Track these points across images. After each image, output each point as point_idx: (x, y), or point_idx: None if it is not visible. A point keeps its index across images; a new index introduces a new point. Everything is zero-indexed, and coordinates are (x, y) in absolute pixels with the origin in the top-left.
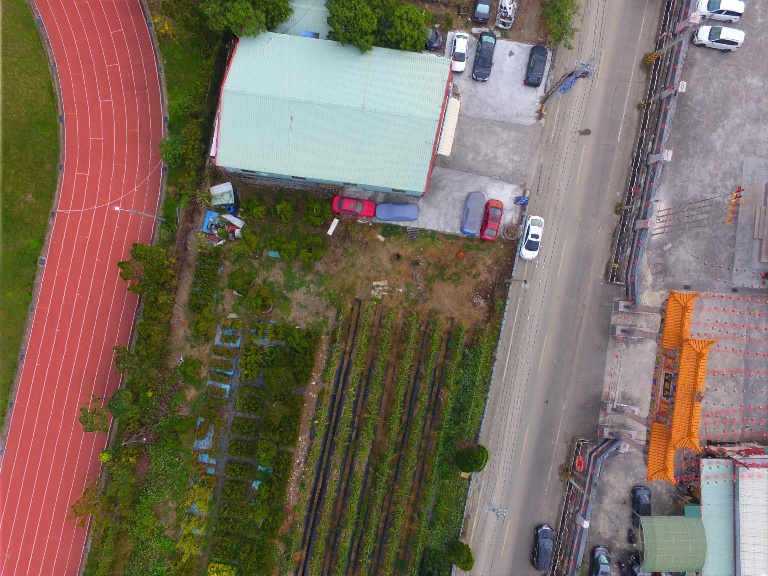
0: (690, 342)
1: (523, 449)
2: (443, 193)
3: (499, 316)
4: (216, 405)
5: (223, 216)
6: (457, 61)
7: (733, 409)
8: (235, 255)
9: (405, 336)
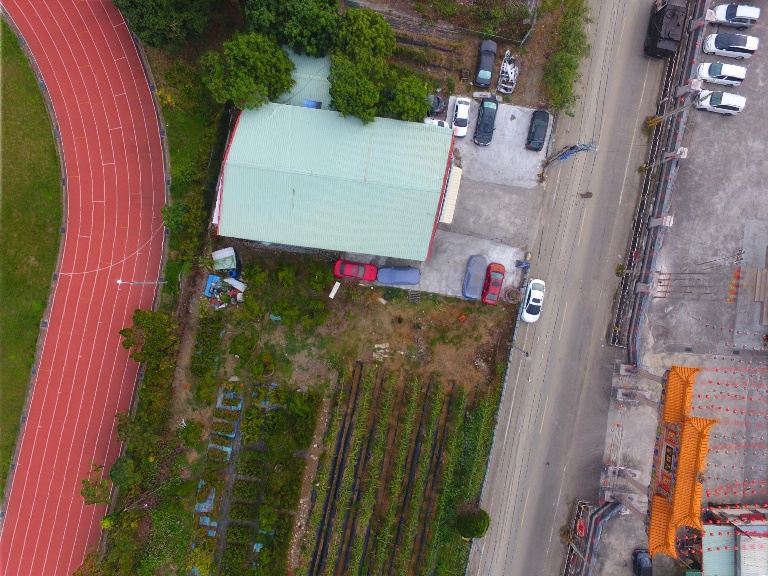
0: (691, 421)
1: (524, 511)
2: (445, 256)
3: (500, 379)
4: (217, 468)
5: (225, 280)
6: (459, 126)
7: (734, 471)
8: None
9: (406, 399)
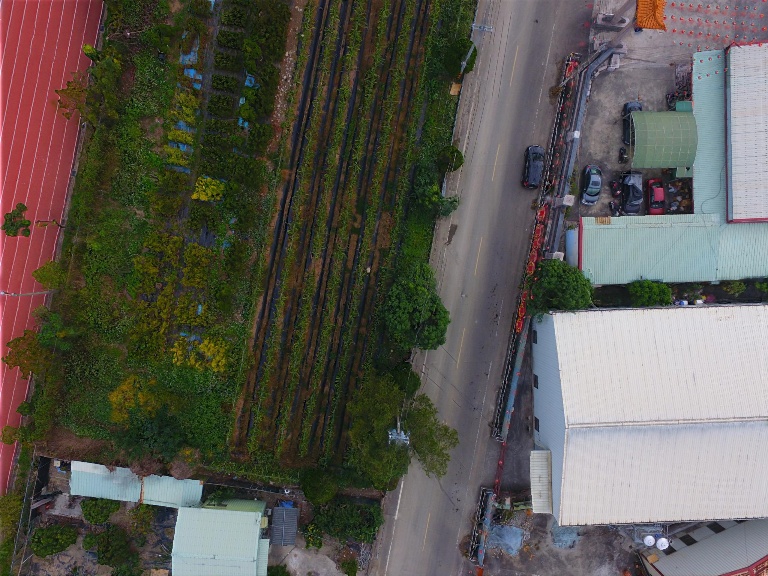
0: None
1: (513, 70)
2: None
3: None
4: (201, 18)
5: None
6: None
7: (725, 27)
8: None
9: None
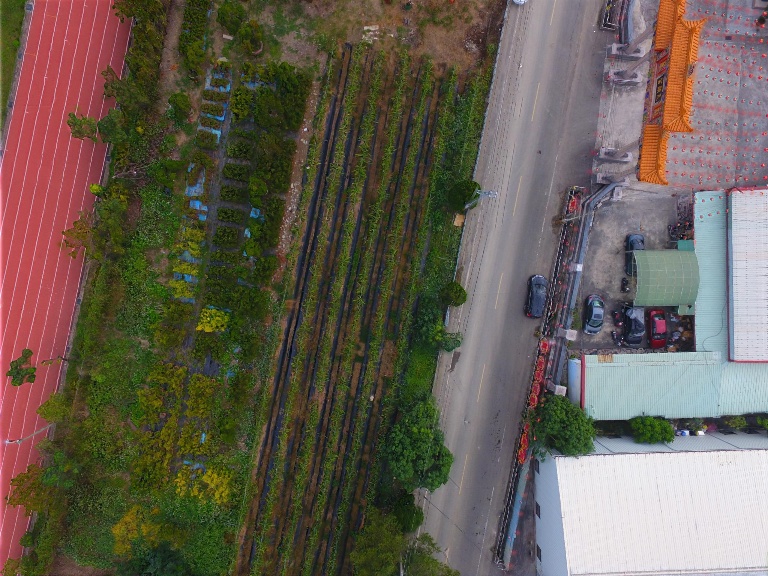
0: (682, 19)
1: (516, 200)
2: None
3: (491, 61)
4: (207, 151)
5: None
6: None
7: (726, 158)
8: None
9: None
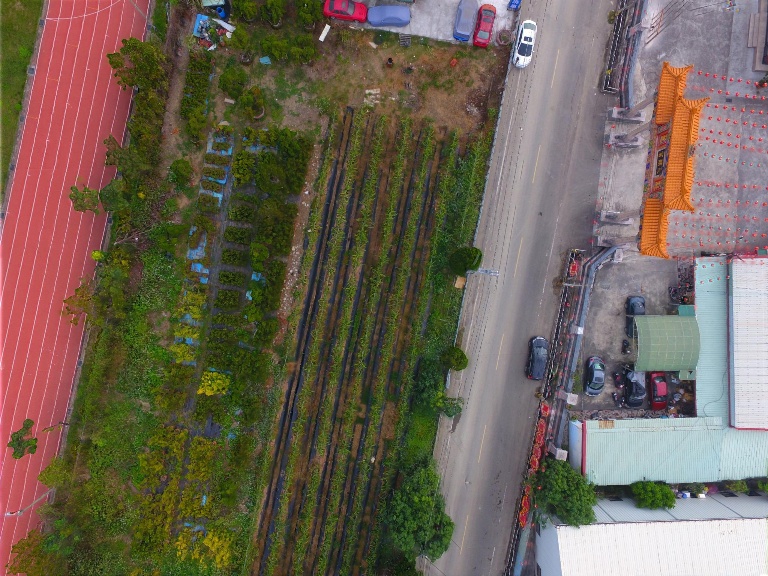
0: (683, 99)
1: (517, 261)
2: None
3: (492, 124)
4: (209, 214)
5: (213, 19)
6: None
7: (727, 220)
8: (226, 62)
9: (398, 144)
